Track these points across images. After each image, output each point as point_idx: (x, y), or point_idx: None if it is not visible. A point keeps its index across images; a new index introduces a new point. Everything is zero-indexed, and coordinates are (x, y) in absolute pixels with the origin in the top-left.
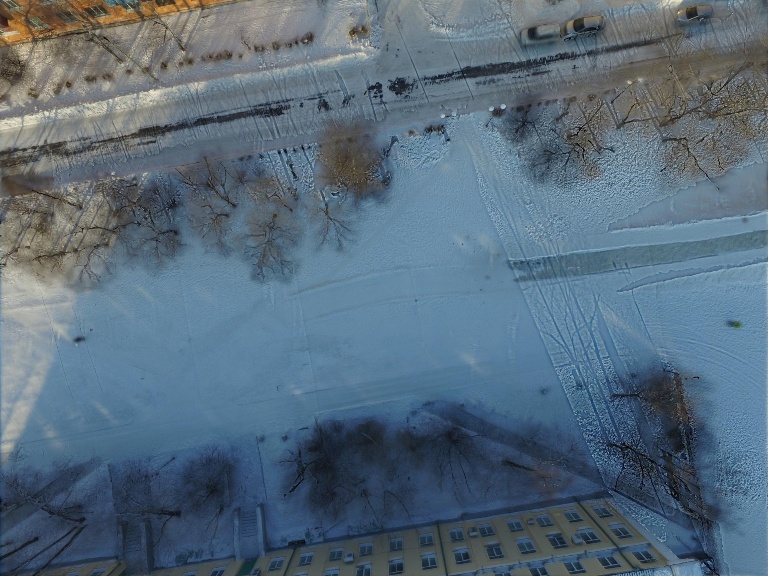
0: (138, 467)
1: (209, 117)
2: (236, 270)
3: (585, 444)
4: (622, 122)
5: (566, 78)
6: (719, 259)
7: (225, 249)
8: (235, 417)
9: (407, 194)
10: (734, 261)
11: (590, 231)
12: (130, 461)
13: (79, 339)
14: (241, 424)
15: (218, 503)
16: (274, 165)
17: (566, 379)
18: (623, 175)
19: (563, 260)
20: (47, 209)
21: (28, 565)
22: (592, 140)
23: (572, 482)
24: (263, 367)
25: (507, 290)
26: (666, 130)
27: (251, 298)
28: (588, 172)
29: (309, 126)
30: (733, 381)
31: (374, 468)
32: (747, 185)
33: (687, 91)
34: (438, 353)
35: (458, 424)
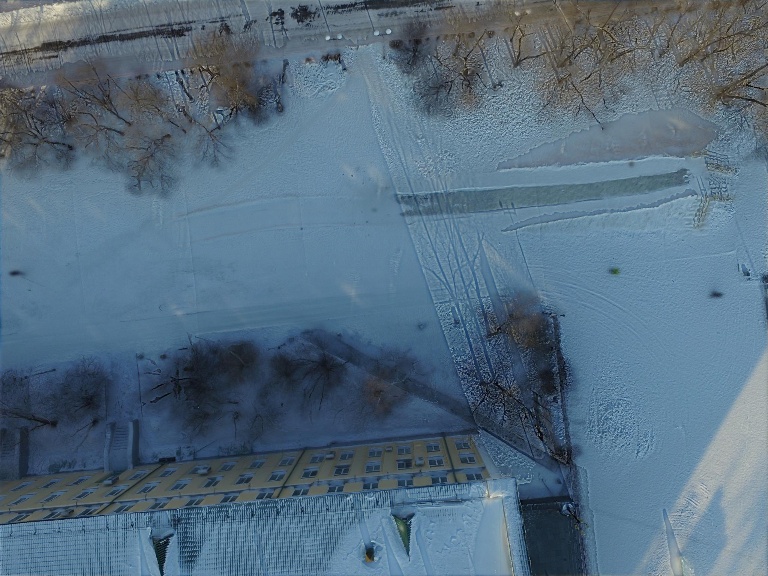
0: (20, 376)
1: (111, 35)
2: (127, 188)
3: (458, 382)
4: (517, 60)
5: (468, 15)
6: (603, 203)
7: (113, 164)
8: (117, 333)
9: (301, 122)
10: (618, 206)
11: (479, 169)
12: (13, 370)
13: None
14: (122, 341)
15: (92, 415)
16: (171, 86)
17: (445, 316)
18: (516, 114)
19: (450, 197)
20: None
21: None
22: (488, 77)
23: (443, 418)
24: (148, 286)
25: (393, 224)
26: (563, 71)
27: (140, 217)
28: (482, 110)
29: (209, 49)
30: (612, 328)
31: (243, 389)
32: (640, 131)
33: (587, 33)
34: (320, 282)
35: (335, 354)
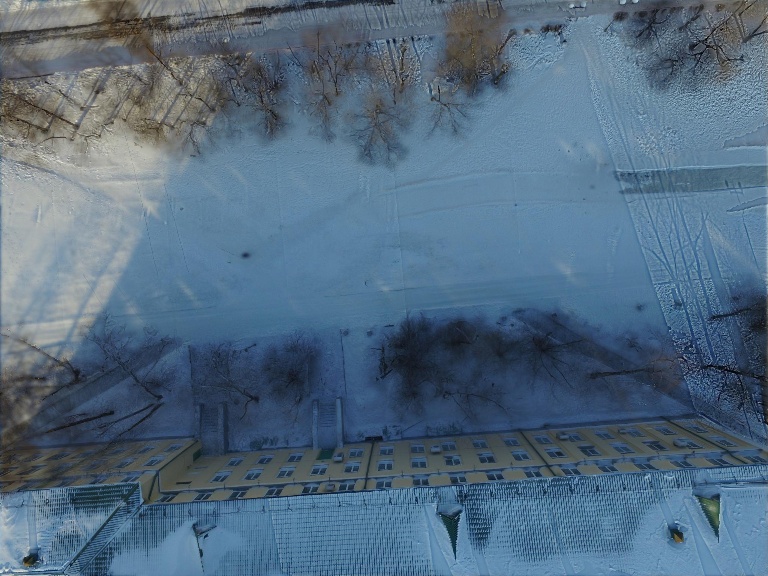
0: None
1: (317, 1)
2: (333, 160)
3: (678, 365)
4: None
5: None
6: None
7: (327, 134)
8: (320, 309)
9: (515, 96)
10: None
11: (704, 147)
12: (211, 344)
13: (169, 217)
14: (326, 316)
15: (299, 391)
16: (381, 55)
17: (664, 297)
18: (745, 91)
19: (673, 175)
20: (146, 82)
21: (102, 438)
22: (715, 52)
23: (661, 402)
24: (353, 261)
25: (611, 201)
26: None
27: (346, 189)
28: (708, 86)
29: (420, 18)
30: None
31: (462, 367)
32: None
33: None
34: (534, 261)
35: None
